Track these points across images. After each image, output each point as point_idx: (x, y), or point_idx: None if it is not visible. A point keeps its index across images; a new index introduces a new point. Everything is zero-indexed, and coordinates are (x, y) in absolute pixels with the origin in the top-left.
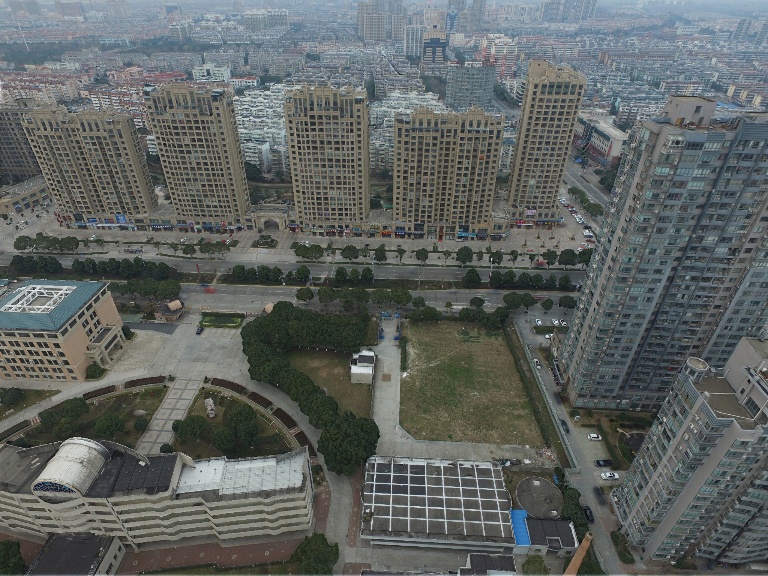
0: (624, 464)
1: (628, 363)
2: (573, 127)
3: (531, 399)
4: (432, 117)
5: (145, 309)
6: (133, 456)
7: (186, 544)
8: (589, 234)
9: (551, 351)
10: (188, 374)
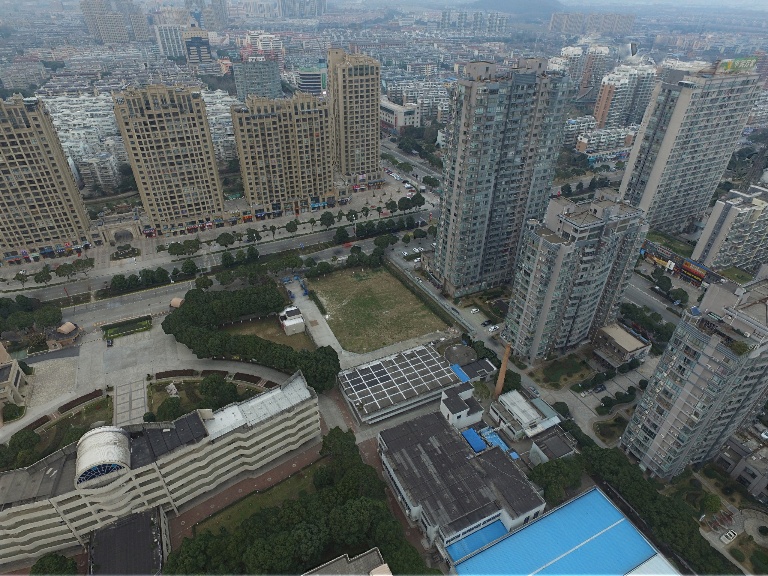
0: (498, 320)
1: (481, 253)
2: (378, 101)
3: (426, 302)
4: (268, 104)
5: (30, 342)
6: (153, 429)
7: (221, 490)
8: (409, 186)
9: (423, 269)
10: (125, 380)
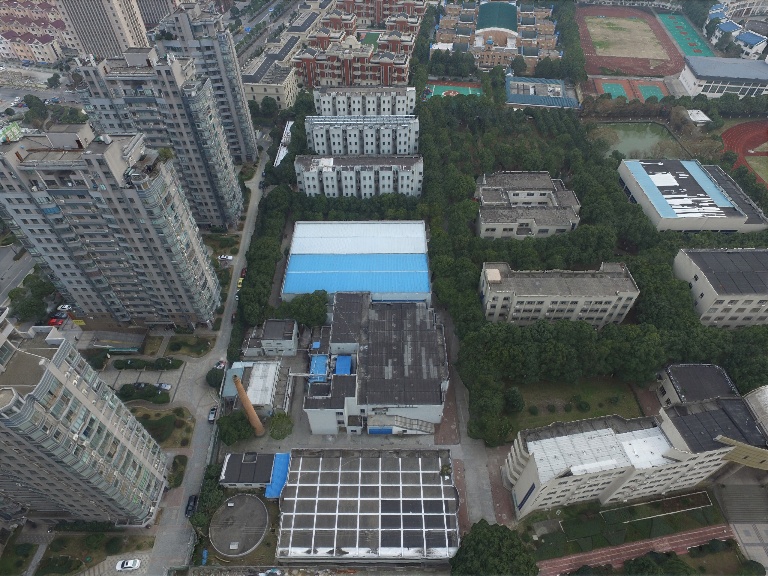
0: None
1: None
2: None
3: None
4: None
5: None
6: None
7: None
8: None
9: None
10: None
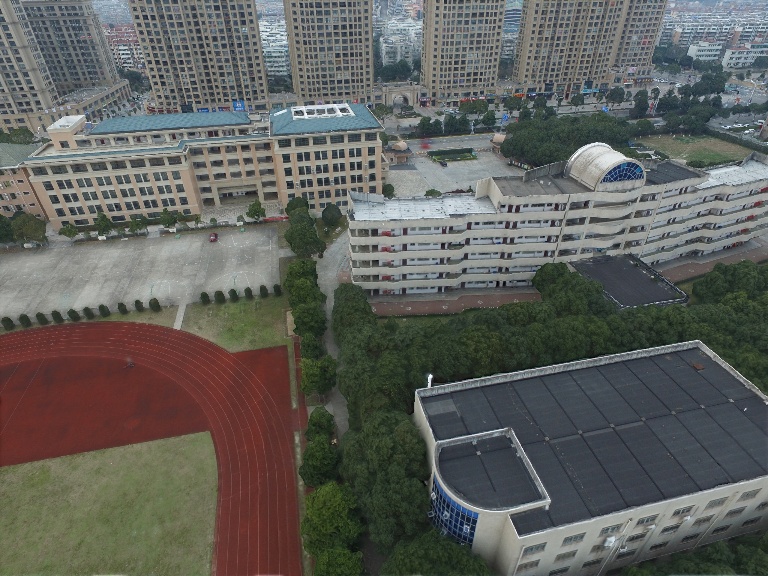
0: None
1: None
2: None
3: None
4: None
5: None
6: None
7: (668, 267)
8: None
9: (765, 137)
10: None
